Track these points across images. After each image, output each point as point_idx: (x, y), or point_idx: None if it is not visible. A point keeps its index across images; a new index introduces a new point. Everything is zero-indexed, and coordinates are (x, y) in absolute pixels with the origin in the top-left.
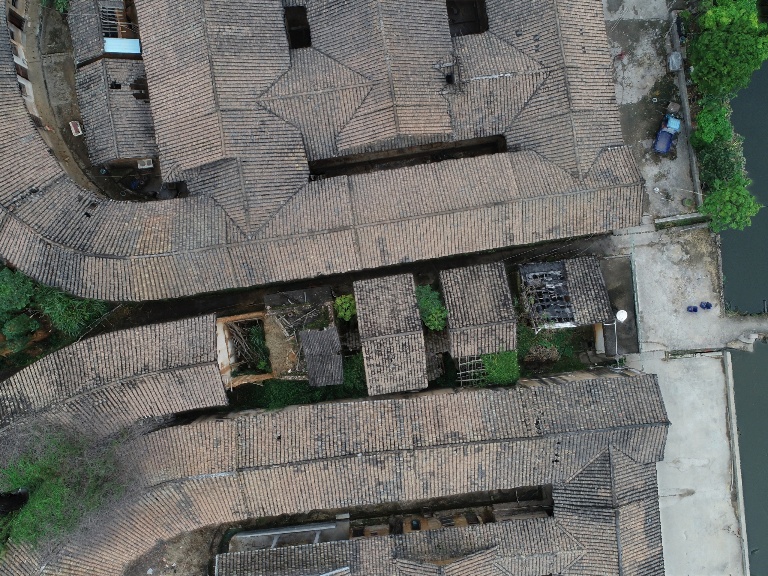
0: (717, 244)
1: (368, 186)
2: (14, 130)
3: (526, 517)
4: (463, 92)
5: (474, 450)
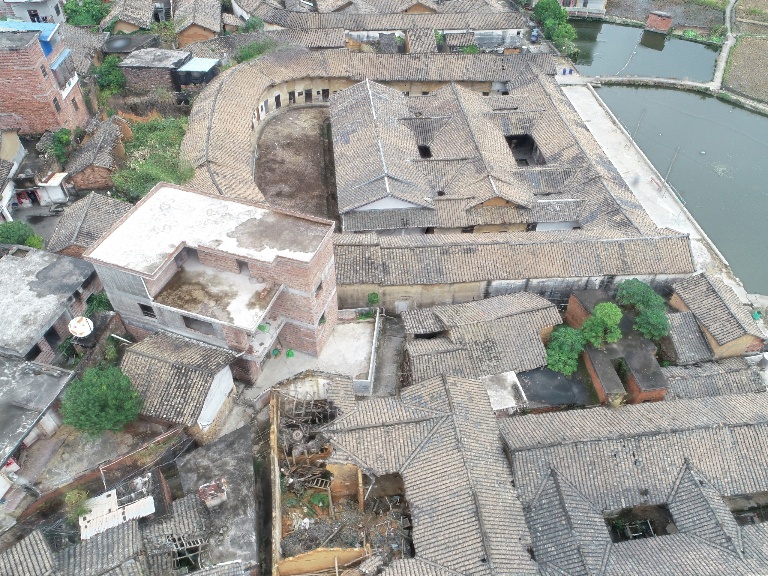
0: (569, 60)
1: None
2: None
3: None
4: (443, 5)
5: (462, 58)
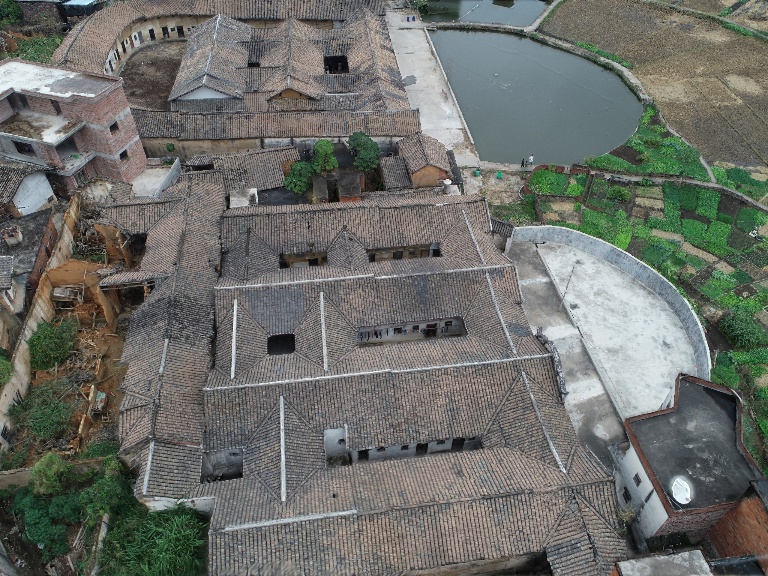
0: (417, 11)
1: None
2: None
3: None
4: None
5: (307, 1)
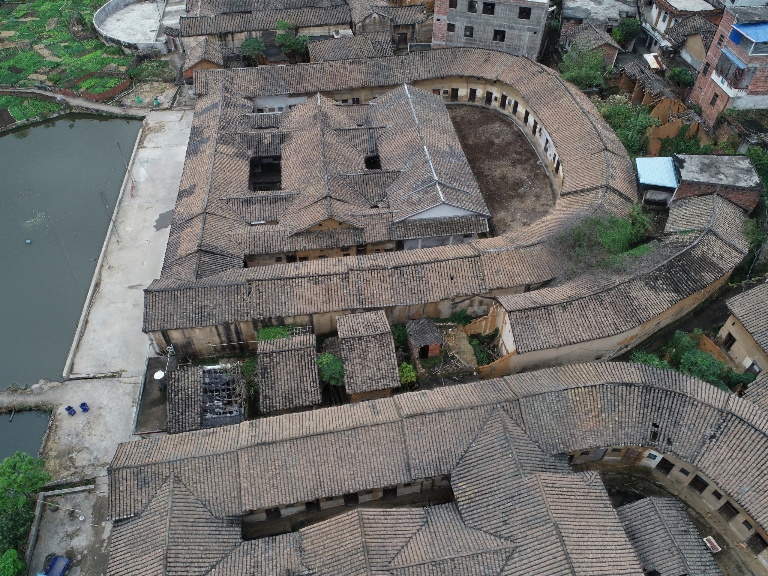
0: None
1: (390, 468)
2: (760, 496)
3: (264, 263)
4: None
5: None
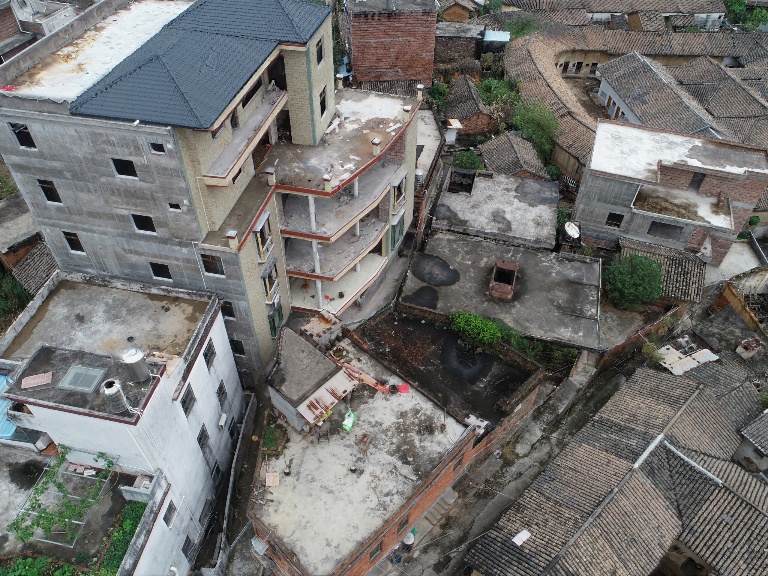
0: None
1: None
2: None
3: None
4: None
5: (698, 35)
